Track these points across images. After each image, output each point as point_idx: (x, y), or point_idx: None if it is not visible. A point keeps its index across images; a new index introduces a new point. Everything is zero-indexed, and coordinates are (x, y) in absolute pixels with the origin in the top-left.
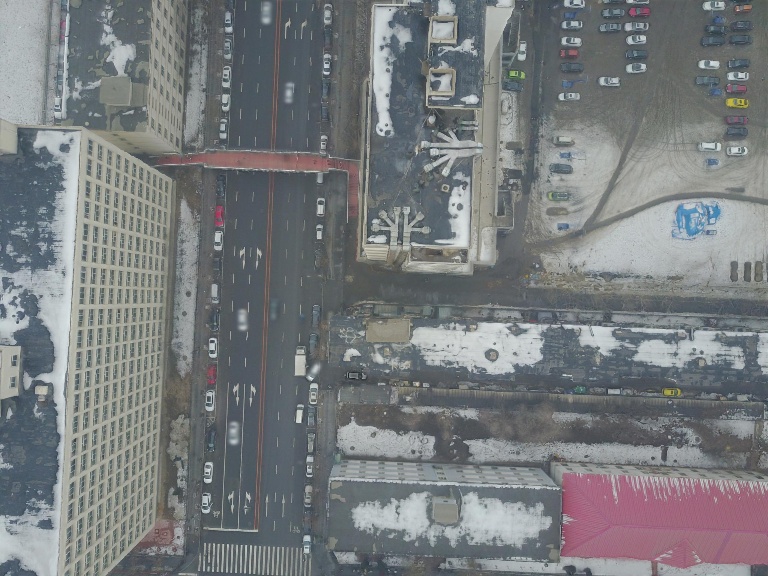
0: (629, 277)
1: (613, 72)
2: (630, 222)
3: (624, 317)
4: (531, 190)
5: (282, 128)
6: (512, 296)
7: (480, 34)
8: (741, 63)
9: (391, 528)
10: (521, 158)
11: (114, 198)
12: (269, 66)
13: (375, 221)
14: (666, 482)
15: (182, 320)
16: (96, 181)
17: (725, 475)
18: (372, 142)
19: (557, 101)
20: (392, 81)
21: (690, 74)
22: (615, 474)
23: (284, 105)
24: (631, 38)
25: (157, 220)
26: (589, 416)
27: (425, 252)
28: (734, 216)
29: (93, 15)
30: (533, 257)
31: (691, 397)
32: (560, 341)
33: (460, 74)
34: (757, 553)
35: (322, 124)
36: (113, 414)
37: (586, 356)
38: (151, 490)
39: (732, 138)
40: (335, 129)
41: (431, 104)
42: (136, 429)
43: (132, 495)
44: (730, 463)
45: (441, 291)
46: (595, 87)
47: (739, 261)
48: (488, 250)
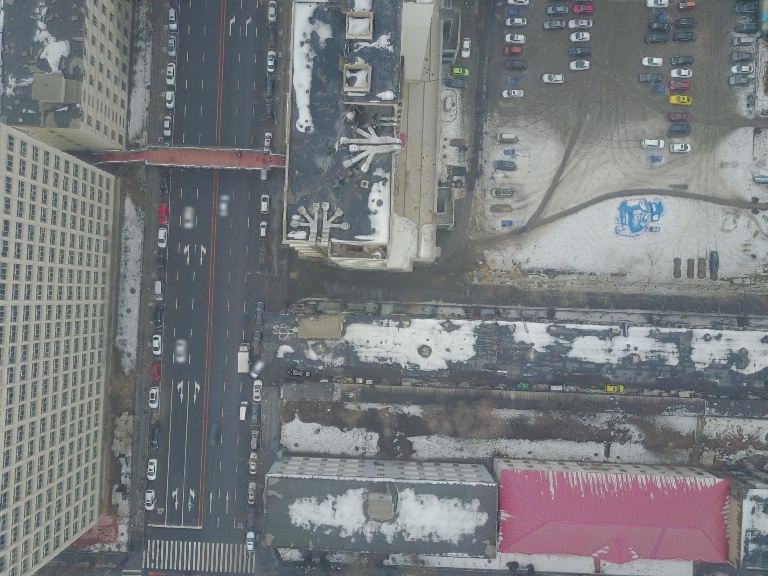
0: (573, 274)
1: (557, 69)
2: (574, 219)
3: (567, 314)
4: (475, 187)
5: (227, 125)
6: (456, 293)
7: (396, 30)
8: (684, 60)
9: (327, 524)
10: (465, 155)
11: (42, 194)
12: (214, 63)
13: (295, 217)
14: (603, 478)
15: (126, 317)
16: (19, 177)
17: (665, 471)
18: (292, 138)
19: (501, 98)
20: (312, 77)
21: (634, 71)
22: (553, 470)
23: (229, 102)
24: (575, 35)
25: (96, 217)
26: (532, 413)
27: (345, 248)
28: (677, 213)
29: (27, 12)
30: (477, 254)
31: (634, 393)
32: (493, 337)
33: (376, 70)
34: (693, 549)
35: (266, 121)
36: (43, 411)
37: (520, 352)
38: (92, 487)
39: (675, 135)
40: (279, 126)
41: (347, 100)
42: (73, 426)
43: (68, 492)
44: (673, 459)
45: (385, 288)
46: (539, 84)
47: (682, 258)
48: (428, 247)
